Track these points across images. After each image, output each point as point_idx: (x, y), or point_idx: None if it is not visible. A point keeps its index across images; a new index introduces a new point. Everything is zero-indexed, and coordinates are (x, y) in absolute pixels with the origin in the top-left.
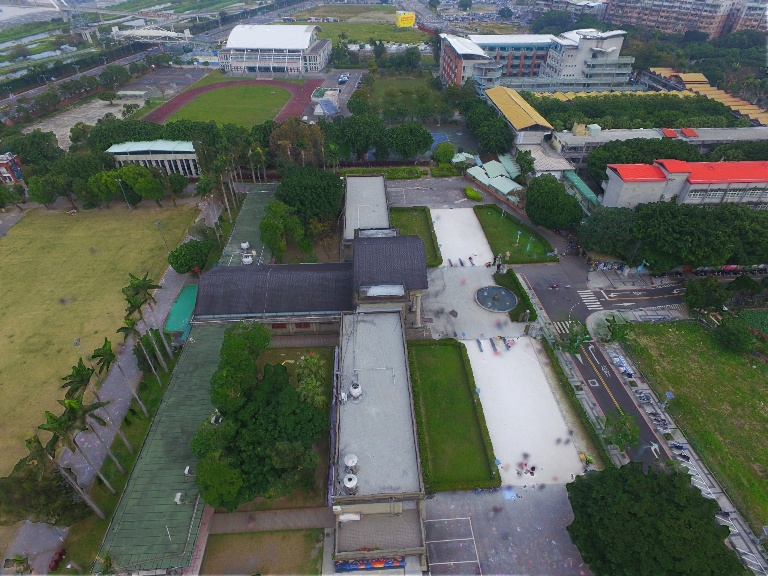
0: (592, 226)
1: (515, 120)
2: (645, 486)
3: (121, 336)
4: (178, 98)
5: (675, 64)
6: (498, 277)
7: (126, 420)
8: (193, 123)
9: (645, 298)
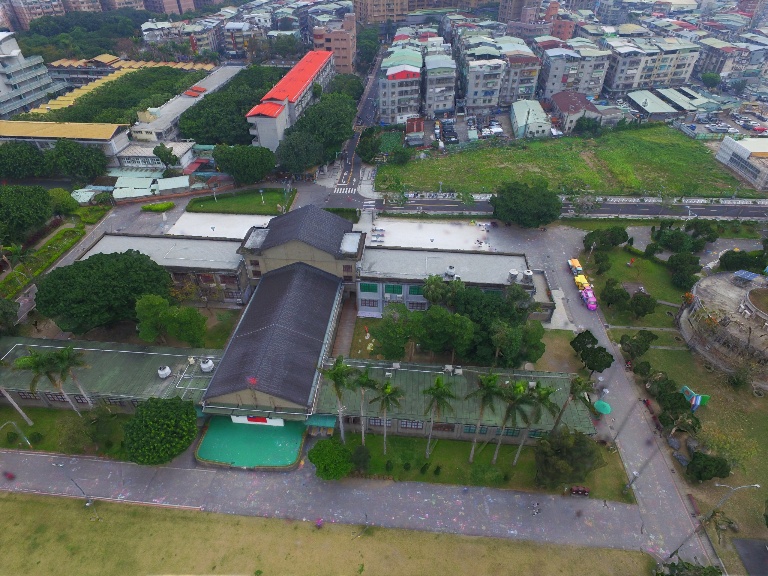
0: (291, 155)
1: (88, 134)
2: (507, 196)
3: (279, 529)
4: None
5: (68, 54)
6: None
7: (439, 468)
8: None
9: (351, 173)
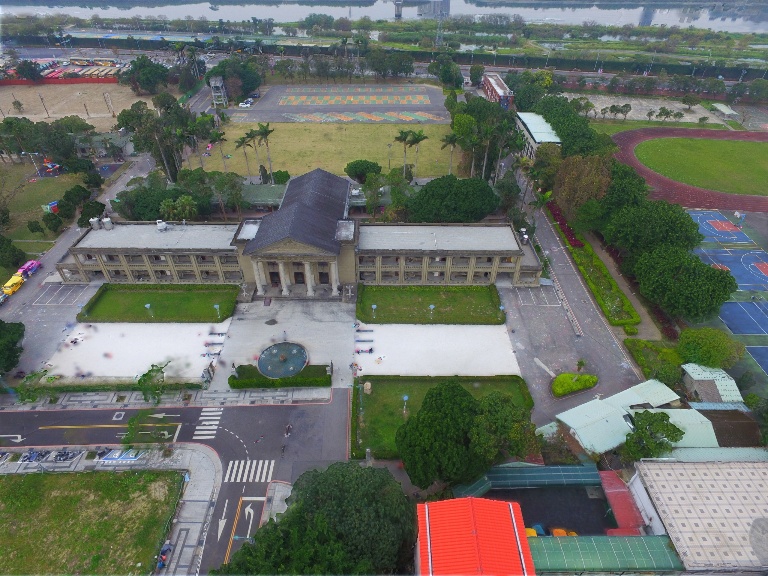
0: None
1: None
2: None
3: None
4: (753, 133)
5: None
6: (320, 367)
7: None
8: (577, 123)
9: None
